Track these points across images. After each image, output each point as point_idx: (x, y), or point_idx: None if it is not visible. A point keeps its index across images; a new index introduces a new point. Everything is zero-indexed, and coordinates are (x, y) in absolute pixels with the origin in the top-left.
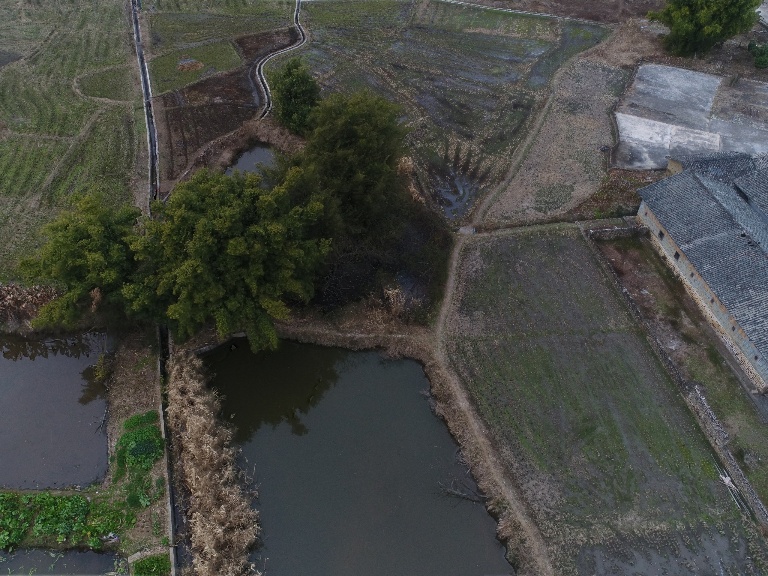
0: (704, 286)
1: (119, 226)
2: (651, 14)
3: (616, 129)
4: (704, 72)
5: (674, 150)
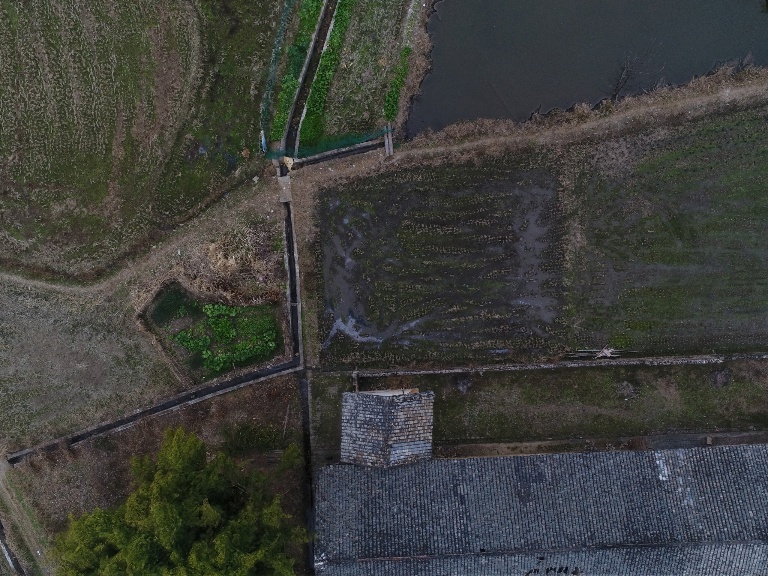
0: None
1: None
2: None
3: None
4: None
5: None
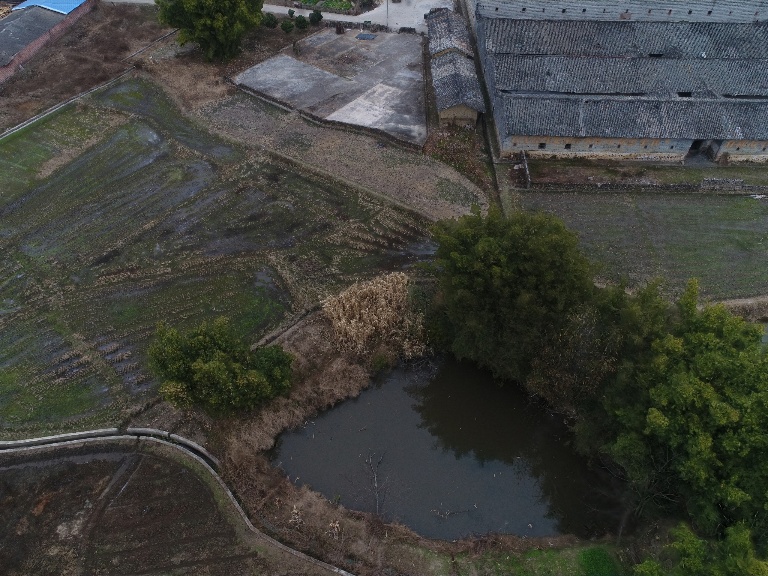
0: (607, 144)
1: (746, 542)
2: (183, 38)
3: (354, 128)
4: (268, 58)
5: (397, 110)
